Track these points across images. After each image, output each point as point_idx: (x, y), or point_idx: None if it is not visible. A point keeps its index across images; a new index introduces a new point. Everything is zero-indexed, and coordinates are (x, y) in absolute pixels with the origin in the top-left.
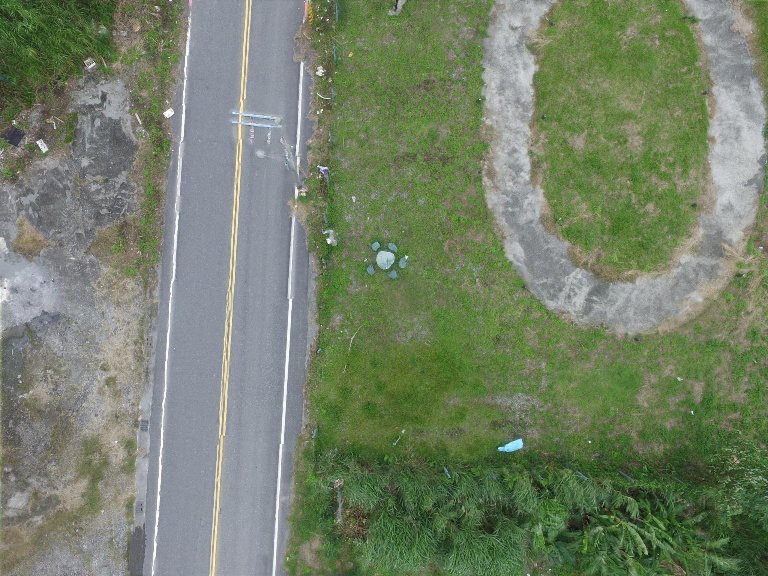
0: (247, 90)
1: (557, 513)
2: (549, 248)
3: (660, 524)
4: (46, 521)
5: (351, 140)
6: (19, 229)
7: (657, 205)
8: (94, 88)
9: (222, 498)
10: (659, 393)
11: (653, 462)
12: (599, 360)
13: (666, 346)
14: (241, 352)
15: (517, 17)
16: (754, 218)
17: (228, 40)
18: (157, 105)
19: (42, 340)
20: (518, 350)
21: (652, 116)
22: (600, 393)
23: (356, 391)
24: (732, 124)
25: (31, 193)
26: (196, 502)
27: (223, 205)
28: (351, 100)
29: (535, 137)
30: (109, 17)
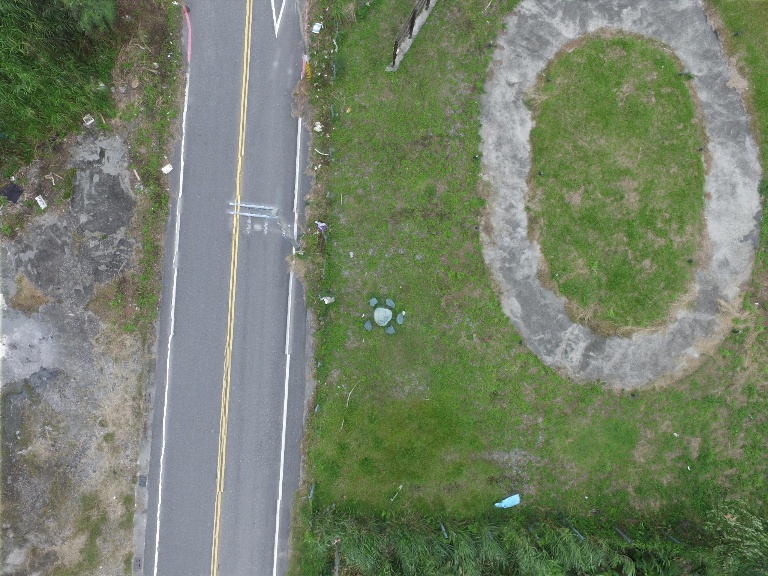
0: (245, 146)
1: (554, 575)
2: (546, 303)
3: None
4: None
5: (349, 196)
6: (18, 285)
7: (653, 261)
8: (93, 144)
9: (220, 554)
10: (655, 449)
11: (649, 518)
12: (596, 416)
13: (662, 401)
14: (239, 408)
15: (514, 73)
16: (750, 274)
17: (226, 96)
18: (155, 161)
19: (41, 396)
20: (515, 405)
21: (648, 173)
22: (597, 449)
23: (354, 446)
24: (728, 180)
25: (30, 249)
26: (194, 558)
27: (221, 261)
28: (349, 156)
29: (532, 193)
30: (108, 74)
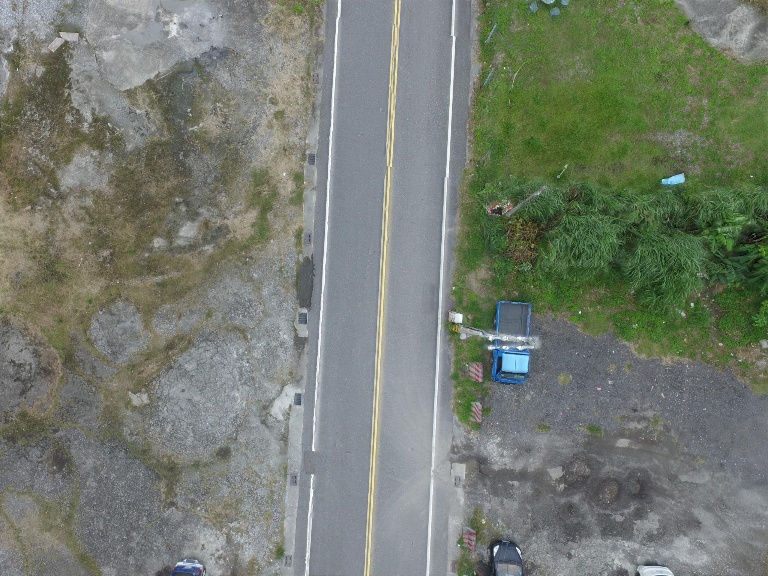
0: None
1: (737, 216)
2: None
3: None
4: (217, 250)
5: None
6: None
7: None
8: None
9: (389, 228)
10: None
11: None
12: (761, 96)
13: None
14: (406, 88)
15: None
16: None
17: None
18: None
19: (211, 75)
20: (679, 87)
21: None
22: (762, 128)
23: (519, 127)
24: None
25: None
26: (364, 232)
27: None
28: None
29: None
30: None
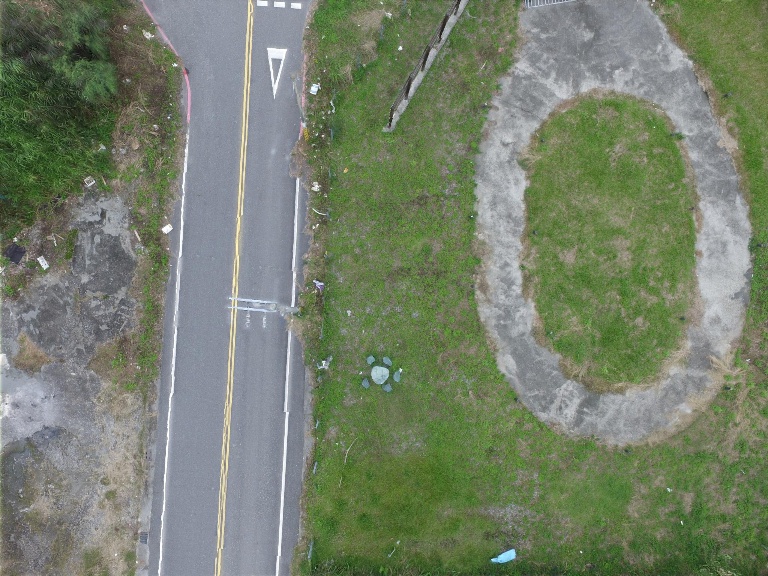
0: (244, 206)
1: None
2: (541, 360)
3: None
4: None
5: (346, 255)
6: (20, 345)
7: (646, 319)
8: (94, 205)
9: None
10: (649, 504)
11: (643, 573)
12: (590, 471)
13: (656, 457)
14: (239, 465)
15: (508, 133)
16: (741, 331)
17: (225, 156)
18: (156, 222)
19: (43, 454)
20: (511, 461)
21: (641, 232)
22: (591, 504)
23: (352, 503)
24: (719, 238)
25: (32, 309)
26: None
27: (221, 320)
28: (346, 215)
29: (526, 251)
30: (109, 137)
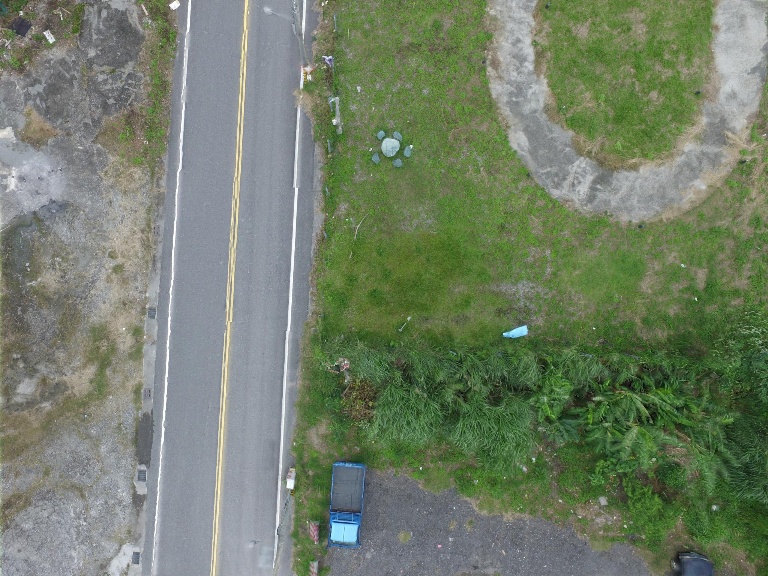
0: None
1: (562, 386)
2: (553, 137)
3: (665, 397)
4: (55, 407)
5: (356, 31)
6: (27, 118)
7: (660, 93)
8: None
9: (229, 383)
10: (663, 280)
11: (657, 346)
12: (603, 247)
13: (670, 233)
14: (247, 240)
15: None
16: (757, 106)
17: None
18: None
19: (50, 228)
20: (523, 238)
21: (655, 4)
22: (604, 280)
23: (362, 279)
24: (735, 13)
25: (38, 83)
26: (203, 388)
27: (229, 95)
28: None
29: (539, 27)
30: None
